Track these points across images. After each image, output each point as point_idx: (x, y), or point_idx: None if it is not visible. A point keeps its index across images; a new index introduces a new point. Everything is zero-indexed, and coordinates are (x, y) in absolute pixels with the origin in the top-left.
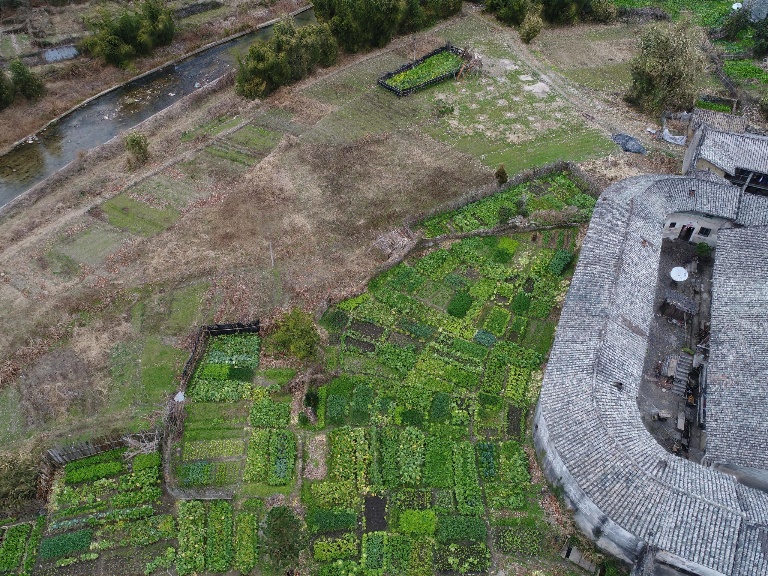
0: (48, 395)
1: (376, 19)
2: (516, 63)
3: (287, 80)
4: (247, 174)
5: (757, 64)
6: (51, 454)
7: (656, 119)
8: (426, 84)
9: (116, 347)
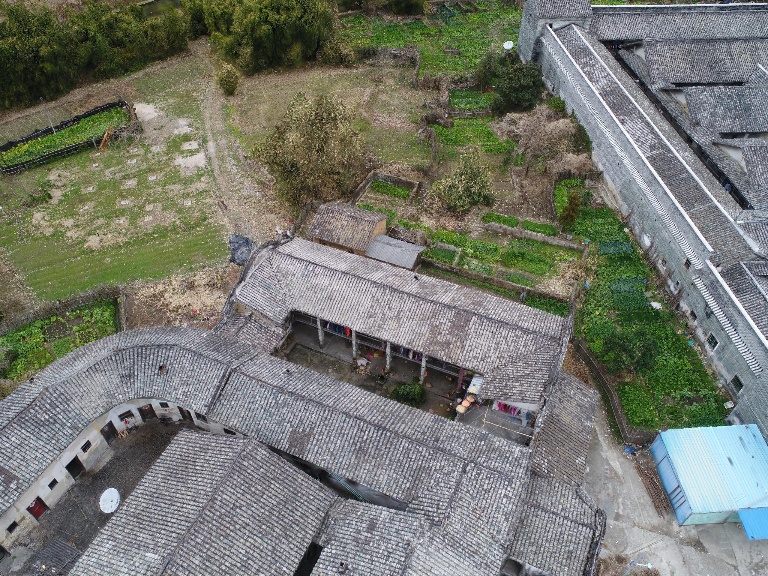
0: None
1: (21, 69)
2: (193, 124)
3: None
4: None
5: (493, 124)
6: None
7: (299, 211)
8: (46, 157)
9: None
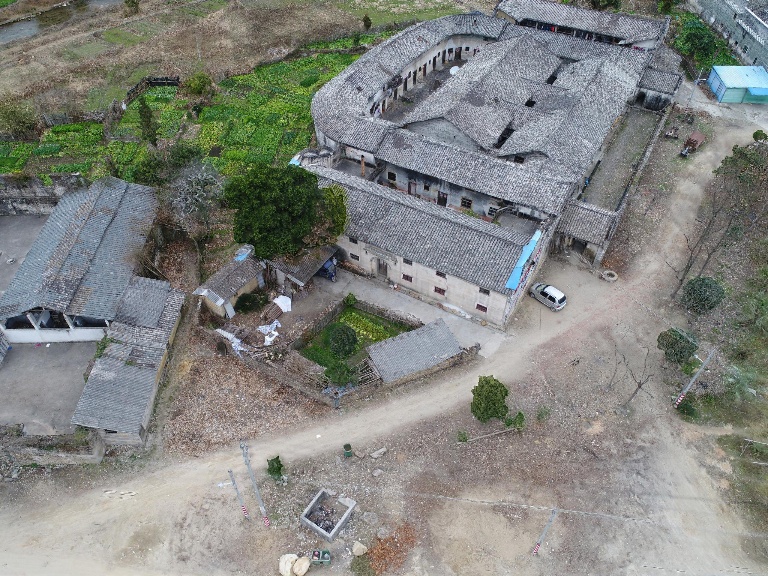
0: (49, 101)
1: None
2: None
3: None
4: (200, 19)
5: None
6: (45, 117)
7: None
8: None
9: (93, 88)
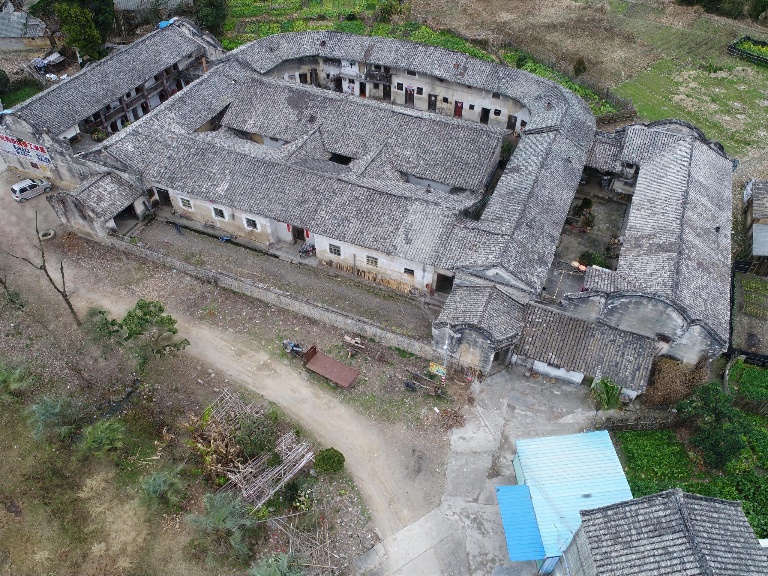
0: None
1: None
2: None
3: (709, 5)
4: None
5: None
6: None
7: None
8: (760, 60)
9: None
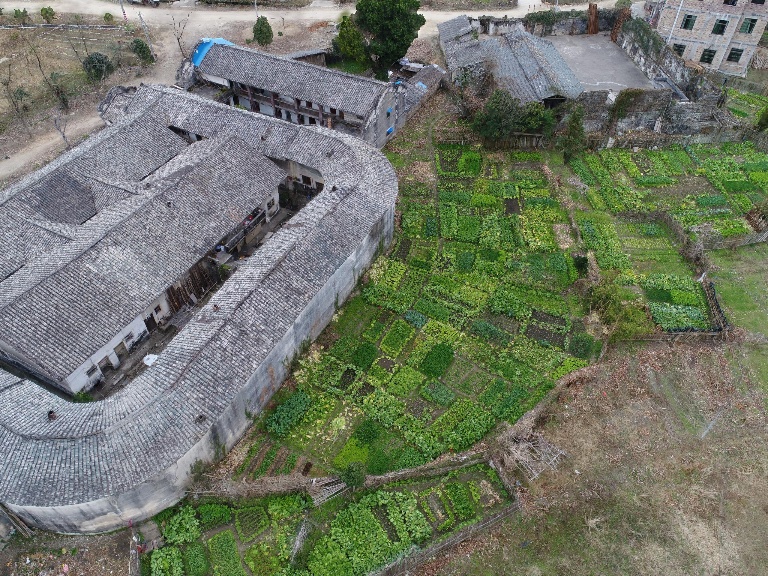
0: None
1: None
2: None
3: None
4: None
5: None
6: None
7: None
8: None
9: None
